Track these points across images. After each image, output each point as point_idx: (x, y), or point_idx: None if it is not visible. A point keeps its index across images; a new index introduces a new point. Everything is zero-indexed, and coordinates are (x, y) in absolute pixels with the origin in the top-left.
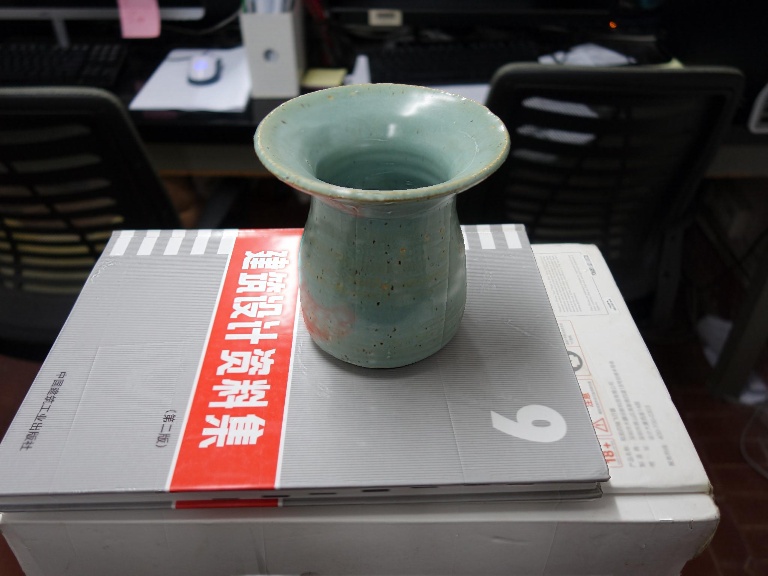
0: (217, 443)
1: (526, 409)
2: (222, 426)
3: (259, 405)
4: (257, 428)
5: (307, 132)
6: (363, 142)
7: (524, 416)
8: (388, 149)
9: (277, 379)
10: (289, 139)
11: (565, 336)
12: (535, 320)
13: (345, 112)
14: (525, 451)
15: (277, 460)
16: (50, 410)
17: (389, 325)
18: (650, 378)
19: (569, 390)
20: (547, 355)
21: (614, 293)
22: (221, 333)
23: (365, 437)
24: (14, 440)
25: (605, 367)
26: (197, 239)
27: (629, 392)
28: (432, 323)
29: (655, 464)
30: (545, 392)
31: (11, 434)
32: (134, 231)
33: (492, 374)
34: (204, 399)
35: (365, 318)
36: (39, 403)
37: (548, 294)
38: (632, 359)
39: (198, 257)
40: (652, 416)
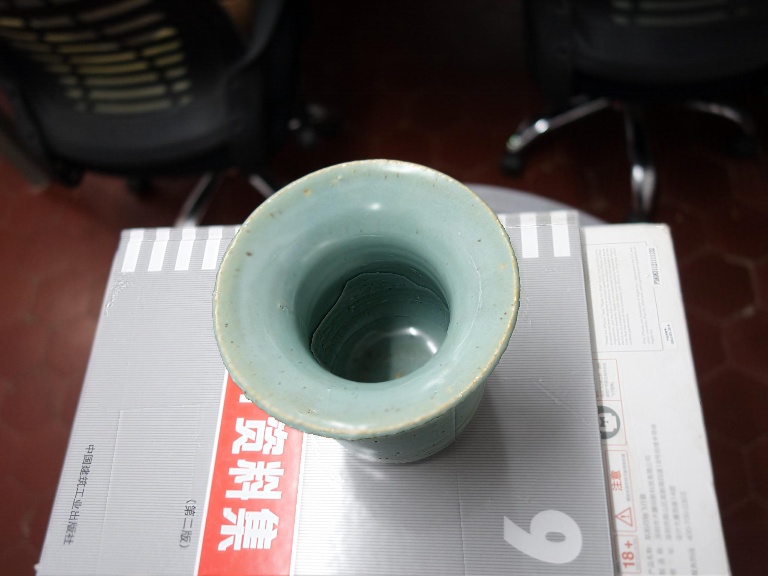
0: (234, 545)
1: (542, 516)
2: (238, 523)
3: (273, 497)
4: (271, 528)
5: (279, 256)
6: (353, 240)
7: (538, 526)
8: (384, 243)
9: (290, 461)
10: (256, 282)
11: (606, 384)
12: (570, 380)
13: (326, 210)
14: (533, 574)
15: (289, 570)
16: (84, 495)
17: (391, 451)
18: (694, 452)
19: (593, 491)
20: (576, 436)
21: (676, 315)
22: (235, 393)
23: (374, 546)
24: (57, 532)
25: (645, 433)
26: (208, 244)
27: (666, 472)
28: (440, 439)
29: (676, 573)
30: (566, 492)
31: (54, 524)
32: (143, 232)
33: (511, 463)
34: (221, 486)
35: (365, 446)
36: (74, 486)
37: (596, 315)
38: (678, 422)
39: (210, 274)
40: (686, 508)
